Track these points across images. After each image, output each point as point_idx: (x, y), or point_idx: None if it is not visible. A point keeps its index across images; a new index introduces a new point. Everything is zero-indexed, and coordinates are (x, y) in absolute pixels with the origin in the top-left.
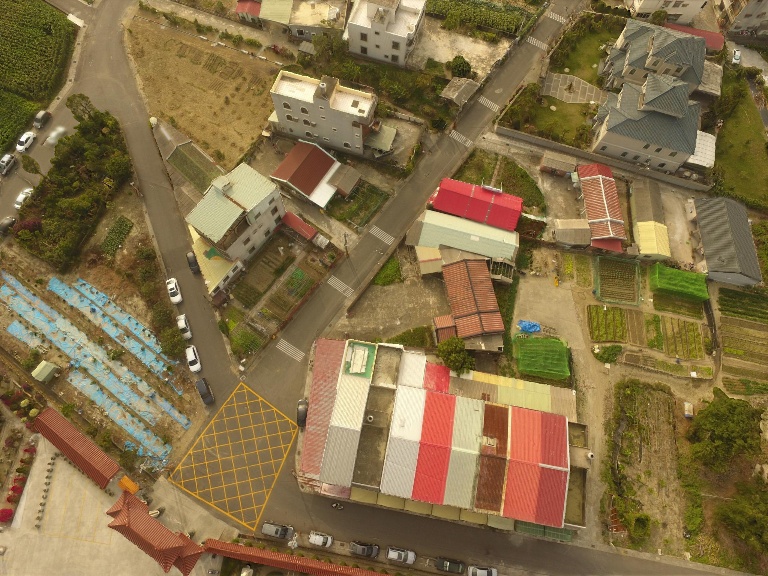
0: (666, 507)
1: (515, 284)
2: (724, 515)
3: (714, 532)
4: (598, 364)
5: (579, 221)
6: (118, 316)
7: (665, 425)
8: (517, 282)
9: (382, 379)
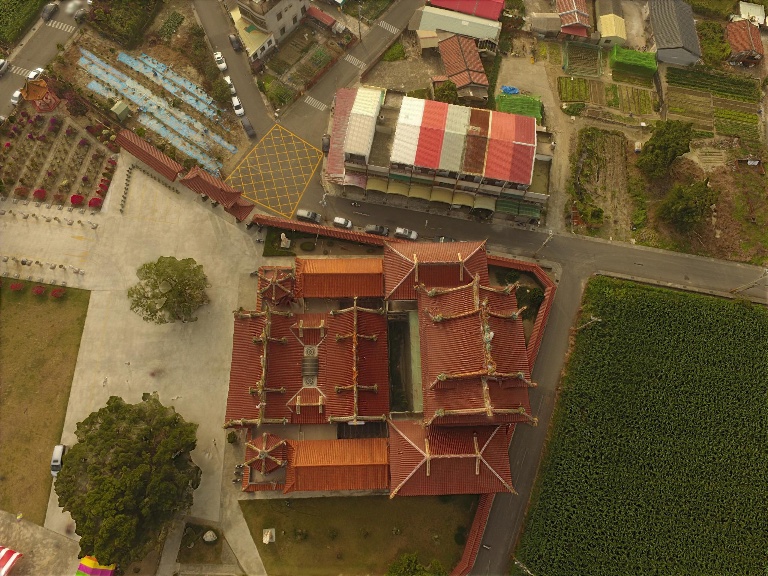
0: (617, 210)
1: (498, 61)
2: (662, 209)
3: (655, 226)
4: (565, 117)
5: (551, 14)
6: (175, 79)
7: (619, 158)
8: (500, 60)
9: None
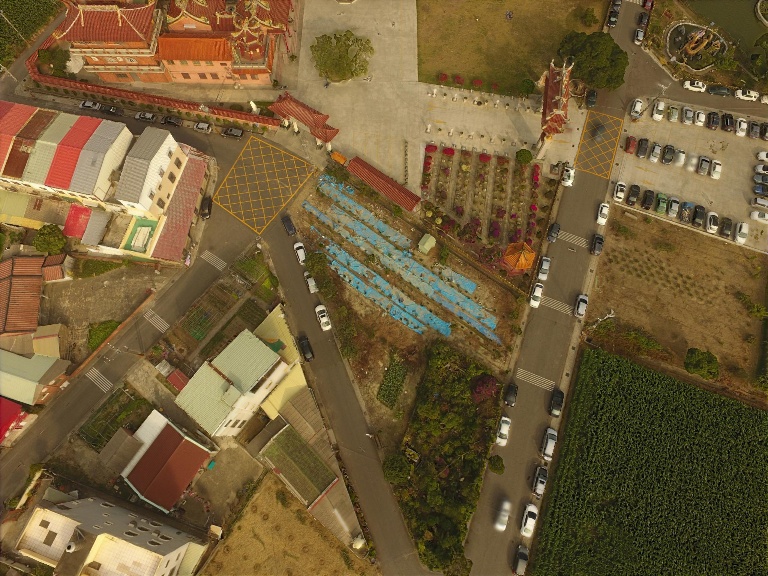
0: None
1: None
2: None
3: None
4: None
5: None
6: (377, 296)
7: None
8: None
9: (124, 223)
